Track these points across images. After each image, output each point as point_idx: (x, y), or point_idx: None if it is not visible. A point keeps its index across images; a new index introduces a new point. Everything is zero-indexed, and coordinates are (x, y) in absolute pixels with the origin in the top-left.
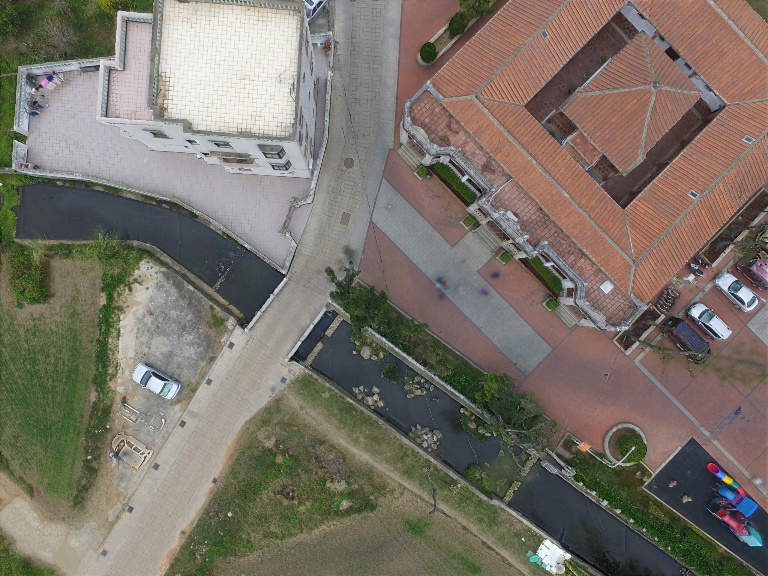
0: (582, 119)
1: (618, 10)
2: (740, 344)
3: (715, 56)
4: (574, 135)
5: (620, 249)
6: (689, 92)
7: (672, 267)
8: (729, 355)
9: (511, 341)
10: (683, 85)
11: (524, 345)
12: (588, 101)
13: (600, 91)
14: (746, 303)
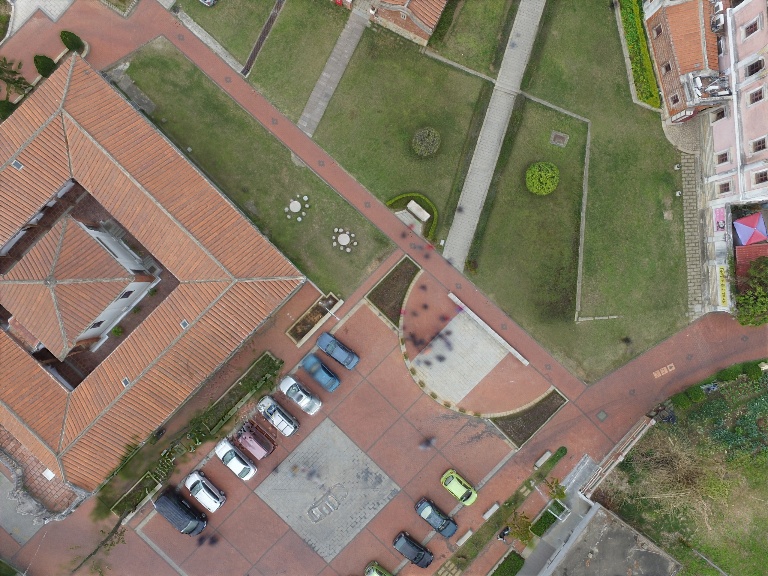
0: (9, 305)
1: (60, 188)
2: (247, 511)
3: (157, 235)
4: (12, 318)
5: (41, 442)
6: (109, 280)
7: (119, 452)
8: (235, 522)
9: (6, 511)
10: (103, 273)
11: (19, 515)
12: (8, 289)
13: (12, 281)
14: (237, 475)
